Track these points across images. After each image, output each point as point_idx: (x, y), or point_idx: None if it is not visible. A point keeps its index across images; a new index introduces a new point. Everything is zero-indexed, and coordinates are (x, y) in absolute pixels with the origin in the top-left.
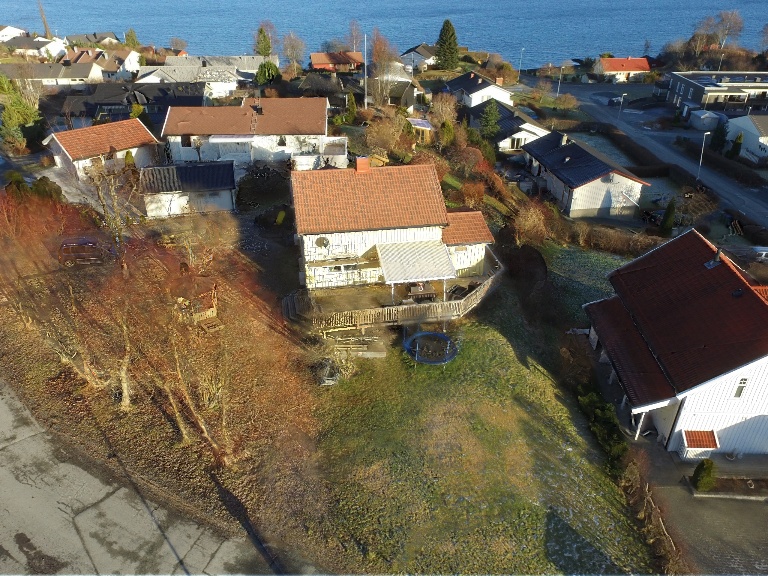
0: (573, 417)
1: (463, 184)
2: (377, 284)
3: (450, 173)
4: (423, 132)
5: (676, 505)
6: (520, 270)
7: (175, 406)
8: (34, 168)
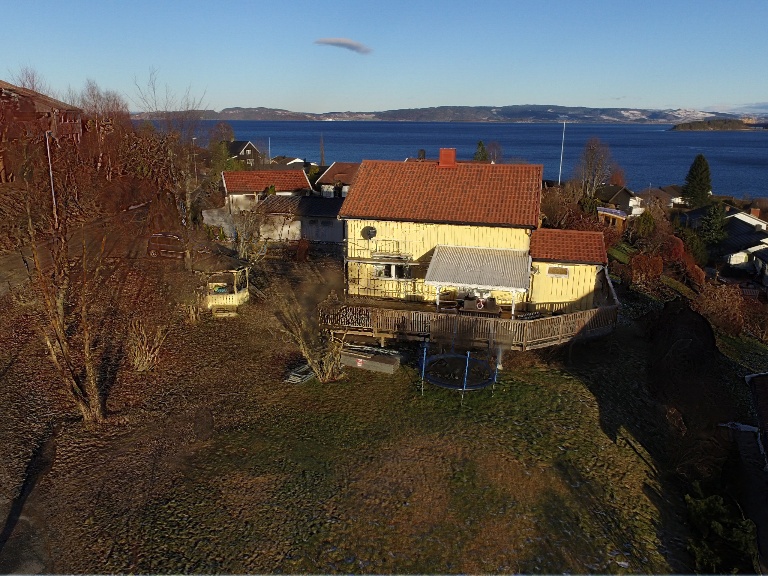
0: (663, 524)
1: None
2: (436, 304)
3: (631, 256)
4: (614, 220)
5: None
6: (661, 329)
7: (62, 331)
8: (208, 207)
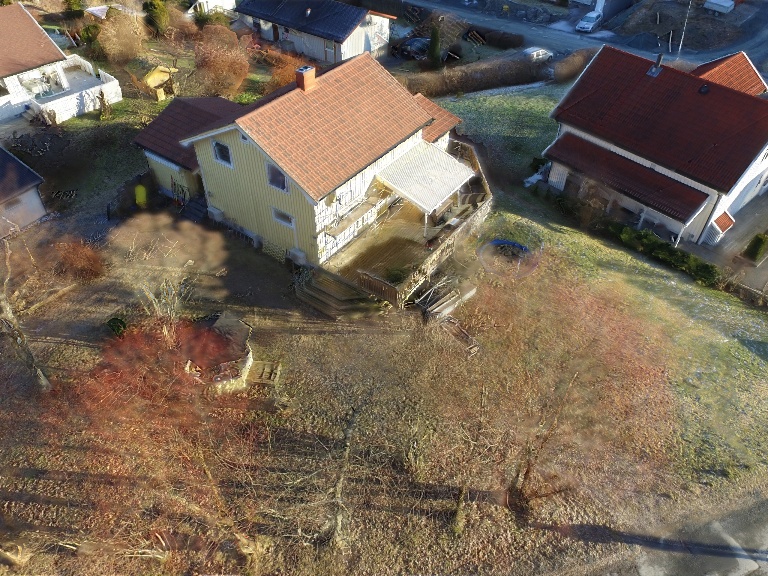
0: (633, 256)
1: (249, 73)
2: (377, 221)
3: None
4: None
5: (760, 281)
6: None
7: None
8: None
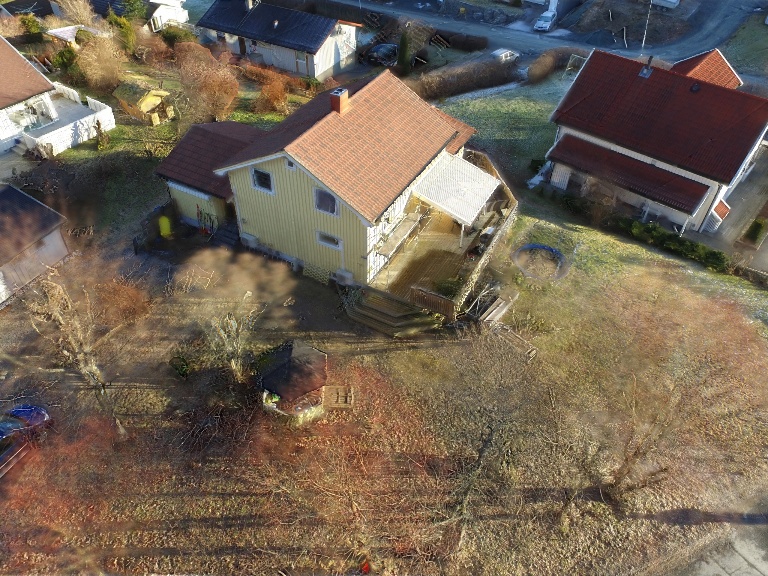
0: (647, 249)
1: None
2: (410, 235)
3: None
4: None
5: (763, 263)
6: None
7: None
8: None
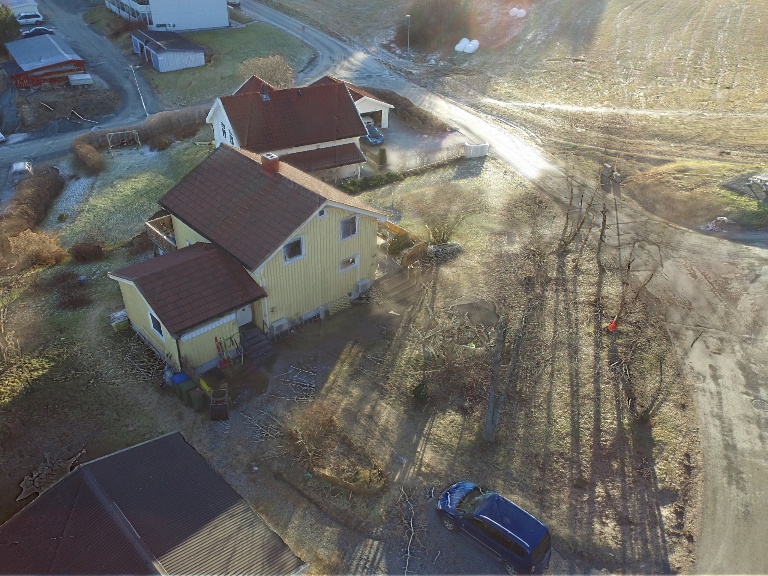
0: None
1: None
2: None
3: None
4: None
5: None
6: None
7: None
8: None
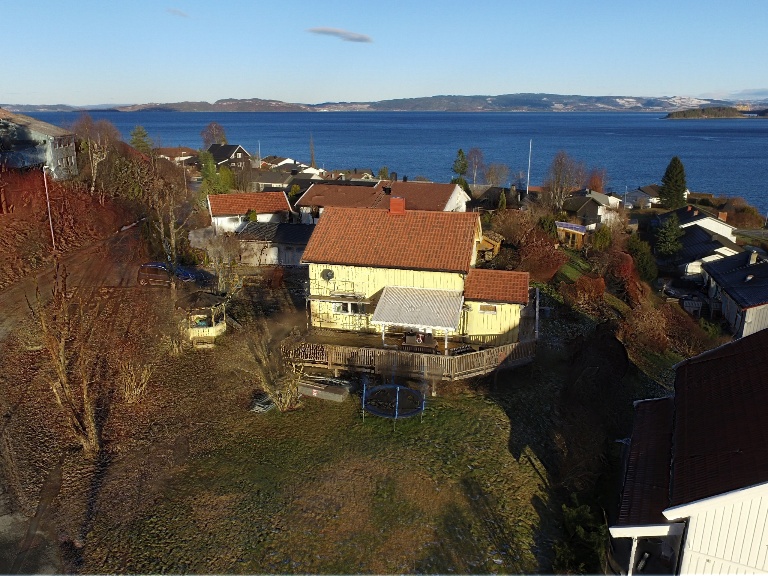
0: (541, 529)
1: None
2: (387, 335)
3: (584, 273)
4: (574, 236)
5: None
6: (579, 356)
7: (65, 375)
8: None
